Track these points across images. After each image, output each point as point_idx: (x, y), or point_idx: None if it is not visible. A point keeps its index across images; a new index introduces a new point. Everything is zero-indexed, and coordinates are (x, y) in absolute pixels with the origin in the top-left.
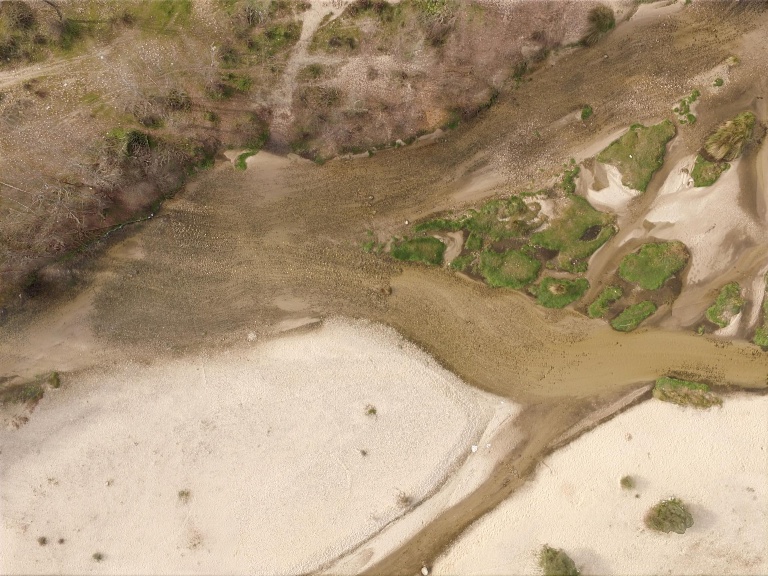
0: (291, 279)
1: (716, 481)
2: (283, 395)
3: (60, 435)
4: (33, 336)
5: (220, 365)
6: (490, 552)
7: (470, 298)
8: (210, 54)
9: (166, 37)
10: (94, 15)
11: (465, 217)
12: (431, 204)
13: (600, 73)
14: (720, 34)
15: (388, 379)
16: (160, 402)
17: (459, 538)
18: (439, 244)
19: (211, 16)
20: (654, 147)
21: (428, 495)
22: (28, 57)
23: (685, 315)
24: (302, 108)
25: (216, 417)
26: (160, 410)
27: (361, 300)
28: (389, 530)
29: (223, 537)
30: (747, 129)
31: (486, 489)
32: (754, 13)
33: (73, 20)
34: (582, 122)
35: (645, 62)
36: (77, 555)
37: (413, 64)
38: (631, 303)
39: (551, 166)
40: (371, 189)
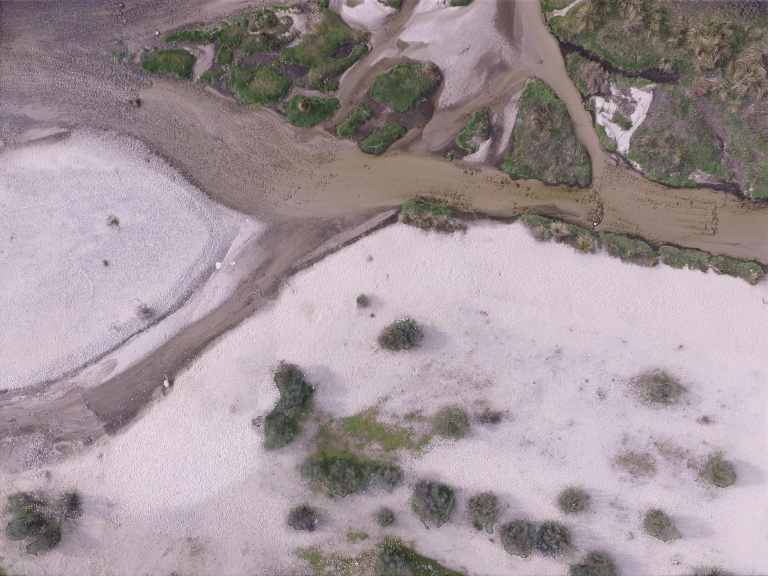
0: (40, 87)
1: (451, 304)
2: (27, 202)
3: None
4: None
5: None
6: (229, 366)
7: (219, 114)
8: None
9: None
10: None
11: (216, 29)
12: (183, 15)
13: None
14: None
15: (132, 191)
16: None
17: (201, 353)
18: (188, 56)
19: None
20: None
21: (172, 309)
22: None
23: (435, 139)
24: None
25: None
26: None
27: (110, 112)
28: (133, 342)
29: None
30: None
31: (230, 306)
32: None
33: None
34: None
35: None
36: None
37: None
38: (381, 125)
39: None
40: None
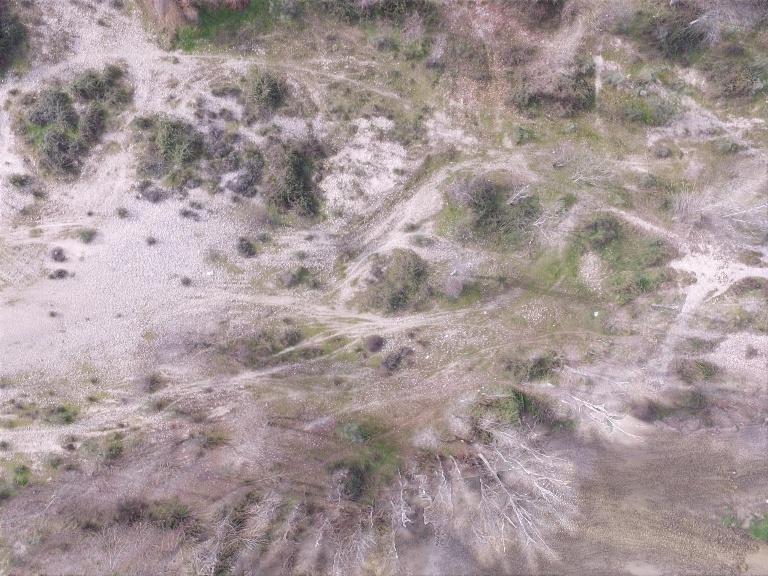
0: (646, 545)
1: None
2: None
3: None
4: None
5: None
6: None
7: None
8: (592, 319)
9: (550, 298)
10: (482, 271)
11: None
12: None
13: None
14: None
15: None
16: None
17: None
18: None
19: (597, 282)
20: None
21: None
22: (415, 307)
23: None
24: (677, 379)
25: None
26: None
27: (715, 574)
28: None
29: None
30: None
31: None
32: None
33: (462, 274)
34: None
35: None
36: None
37: None
38: None
39: None
40: (734, 464)
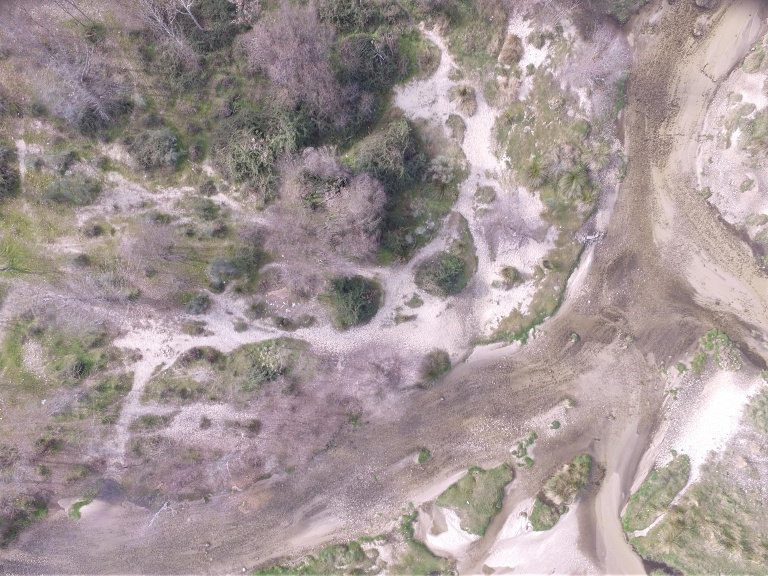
0: None
1: None
2: None
3: None
4: None
5: None
6: None
7: None
8: (40, 408)
9: None
10: None
11: (303, 564)
12: (269, 550)
13: (437, 415)
14: (556, 375)
15: None
16: None
17: None
18: None
19: (41, 369)
20: (491, 493)
21: None
22: None
23: None
24: (135, 459)
25: None
26: None
27: None
28: None
29: None
30: (583, 477)
31: None
32: (590, 353)
33: None
34: (420, 465)
35: (482, 404)
36: None
37: (246, 413)
38: None
39: (389, 510)
40: (208, 536)
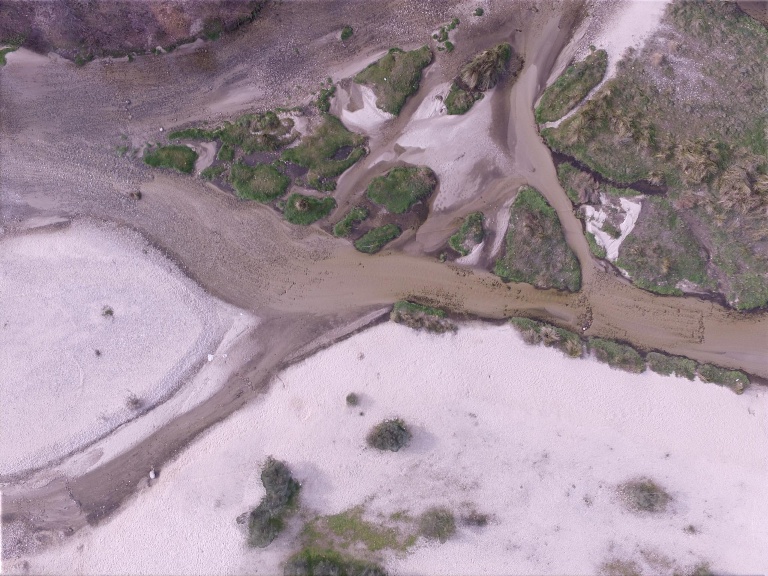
0: (43, 177)
1: (440, 405)
2: (23, 290)
3: None
4: None
5: None
6: (216, 459)
7: (218, 209)
8: None
9: None
10: None
11: (219, 128)
12: (187, 113)
13: None
14: None
15: (128, 282)
16: None
17: (189, 444)
18: (190, 153)
19: None
20: (409, 71)
21: (161, 400)
22: None
23: (428, 241)
24: (63, 7)
25: None
26: None
27: (111, 203)
28: (121, 432)
29: None
30: (500, 59)
31: (220, 398)
32: None
33: None
34: (342, 42)
35: None
36: None
37: None
38: (376, 225)
39: (308, 84)
40: (129, 94)
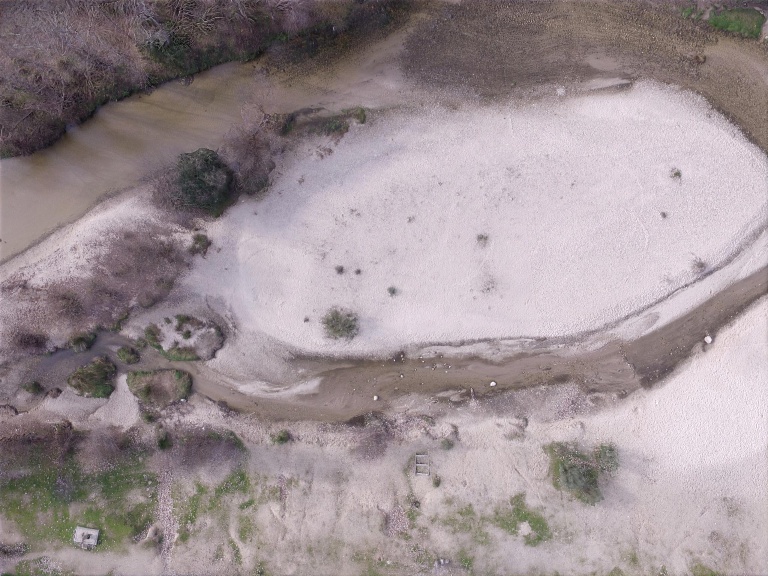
0: (605, 38)
1: None
2: (590, 150)
3: (364, 169)
4: (342, 70)
5: (527, 116)
6: None
7: None
8: None
9: None
10: None
11: None
12: None
13: None
14: None
15: (696, 145)
16: (466, 146)
17: (745, 311)
18: (760, 15)
19: None
20: None
21: (720, 265)
22: None
23: None
24: None
25: (522, 165)
26: (466, 153)
27: (673, 66)
28: (677, 296)
29: (517, 284)
30: None
31: None
32: None
33: None
34: None
35: None
36: (372, 287)
37: None
38: None
39: None
40: None
